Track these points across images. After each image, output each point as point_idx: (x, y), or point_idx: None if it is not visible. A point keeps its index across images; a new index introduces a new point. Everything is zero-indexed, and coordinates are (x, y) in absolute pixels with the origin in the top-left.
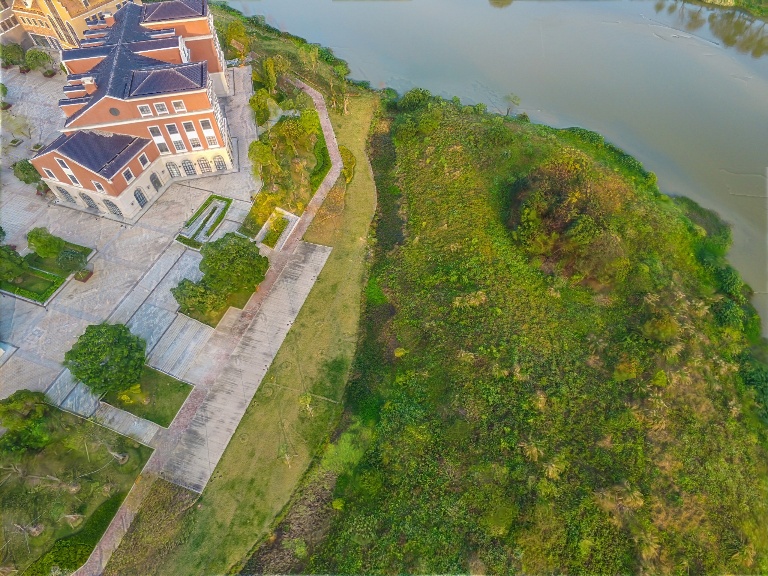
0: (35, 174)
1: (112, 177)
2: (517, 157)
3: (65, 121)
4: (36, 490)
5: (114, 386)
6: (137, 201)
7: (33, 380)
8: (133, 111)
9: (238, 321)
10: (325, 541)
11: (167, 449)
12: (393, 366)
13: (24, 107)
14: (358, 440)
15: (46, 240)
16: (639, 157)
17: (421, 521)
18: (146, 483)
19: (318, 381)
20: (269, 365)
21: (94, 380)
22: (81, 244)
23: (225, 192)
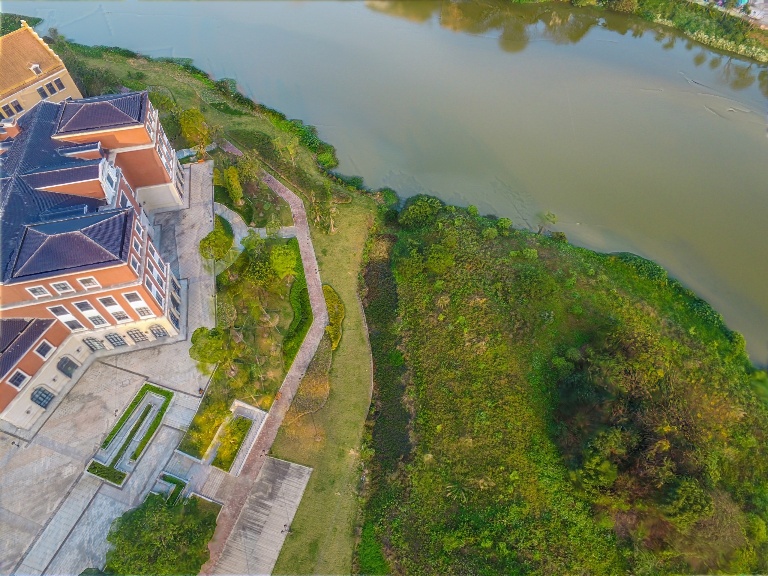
0: None
1: None
2: (561, 318)
3: None
4: None
5: None
6: (36, 404)
7: None
8: (21, 293)
9: None
10: None
11: None
12: None
13: None
14: None
15: None
16: (716, 303)
17: None
18: None
19: None
20: None
21: None
22: None
23: (164, 378)
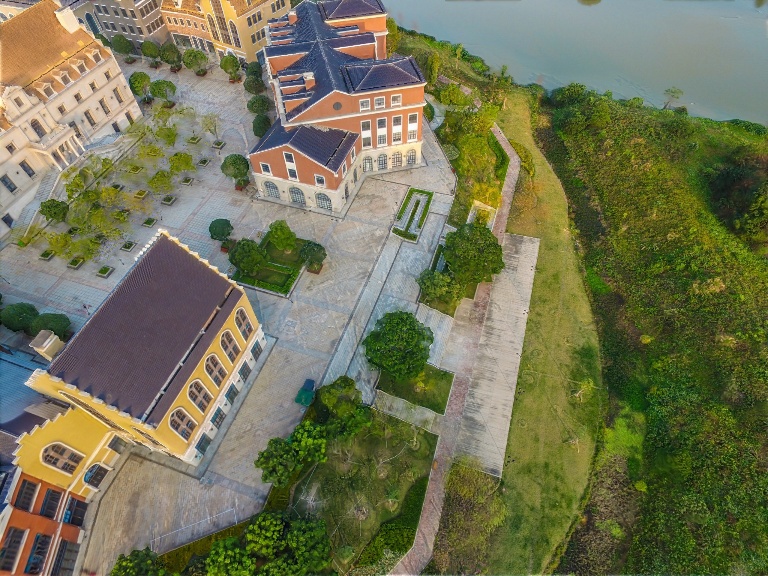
0: (244, 169)
1: (337, 170)
2: (702, 148)
3: (285, 116)
4: (349, 475)
5: (415, 372)
6: None
7: (305, 369)
8: (354, 105)
9: (473, 311)
10: (640, 522)
11: (451, 435)
12: (642, 353)
13: (188, 105)
14: (633, 425)
15: (288, 232)
16: None
17: (743, 501)
18: (442, 468)
19: (574, 368)
20: (520, 353)
21: (401, 366)
22: (299, 237)
23: (422, 185)
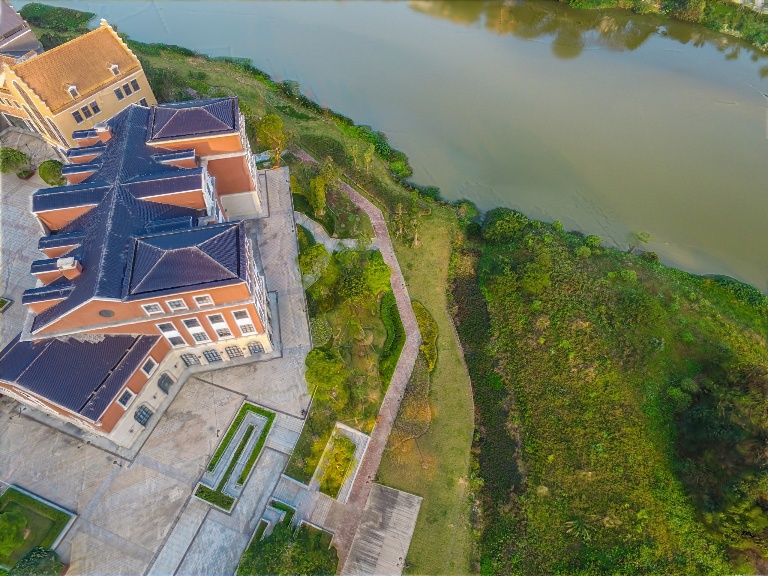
0: None
1: (101, 415)
2: (670, 345)
3: (32, 320)
4: None
5: None
6: (138, 422)
7: None
8: (135, 310)
9: None
10: None
11: None
12: None
13: None
14: None
15: None
16: None
17: None
18: None
19: None
20: None
21: None
22: (54, 500)
23: (264, 397)
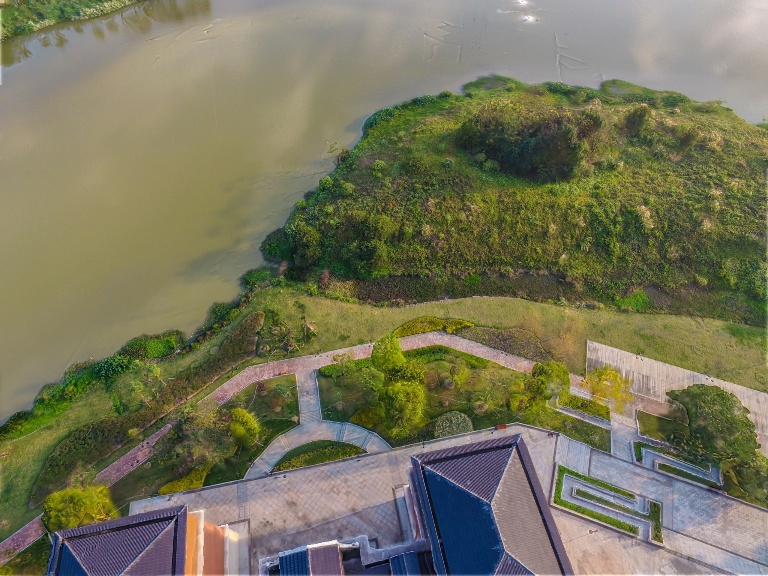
0: None
1: None
2: None
3: None
4: None
5: None
6: None
7: None
8: None
9: None
10: None
11: None
12: (714, 288)
13: None
14: None
15: None
16: (416, 95)
17: None
18: None
19: (762, 348)
20: None
21: None
22: None
23: (541, 482)
